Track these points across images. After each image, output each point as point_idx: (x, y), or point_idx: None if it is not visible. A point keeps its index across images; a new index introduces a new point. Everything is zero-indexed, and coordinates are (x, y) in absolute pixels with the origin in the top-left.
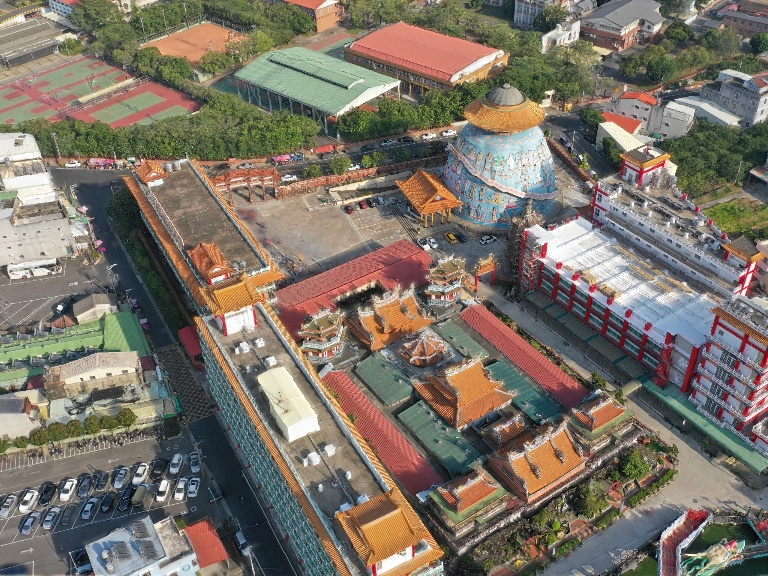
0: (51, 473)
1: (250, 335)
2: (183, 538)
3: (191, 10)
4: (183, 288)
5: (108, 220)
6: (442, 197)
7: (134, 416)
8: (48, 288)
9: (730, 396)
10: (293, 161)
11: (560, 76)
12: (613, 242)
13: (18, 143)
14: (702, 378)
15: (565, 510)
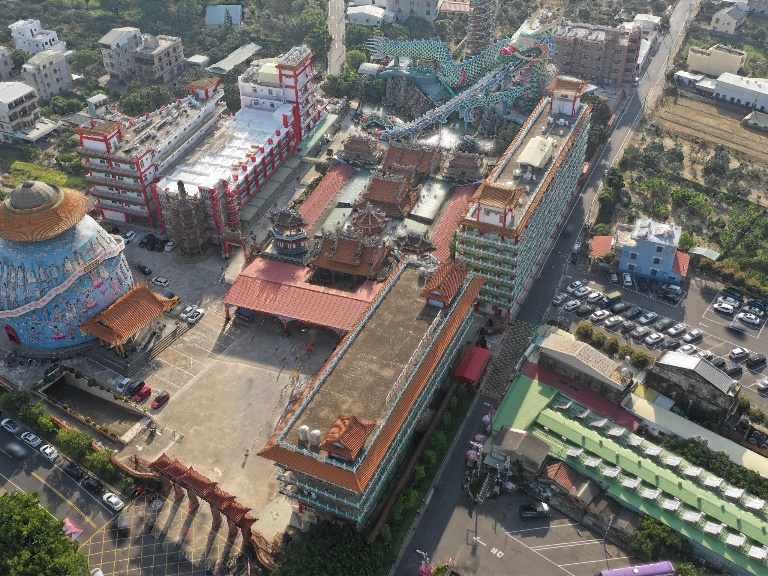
0: None
1: None
2: None
3: None
4: None
5: None
6: None
7: None
8: (529, 572)
9: None
10: None
11: None
12: (183, 166)
13: None
14: None
15: None
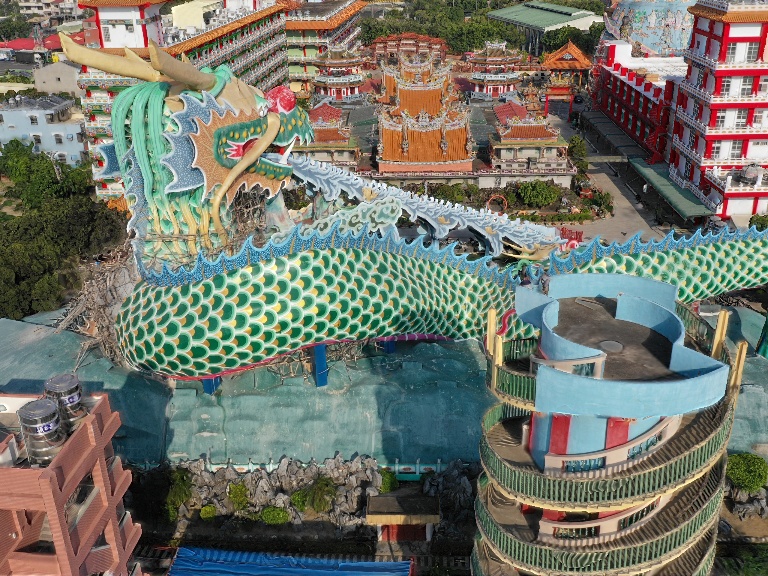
0: None
1: None
2: None
3: (506, 0)
4: None
5: None
6: (573, 57)
7: None
8: None
9: (699, 140)
10: None
11: None
12: None
13: None
14: (684, 133)
15: None
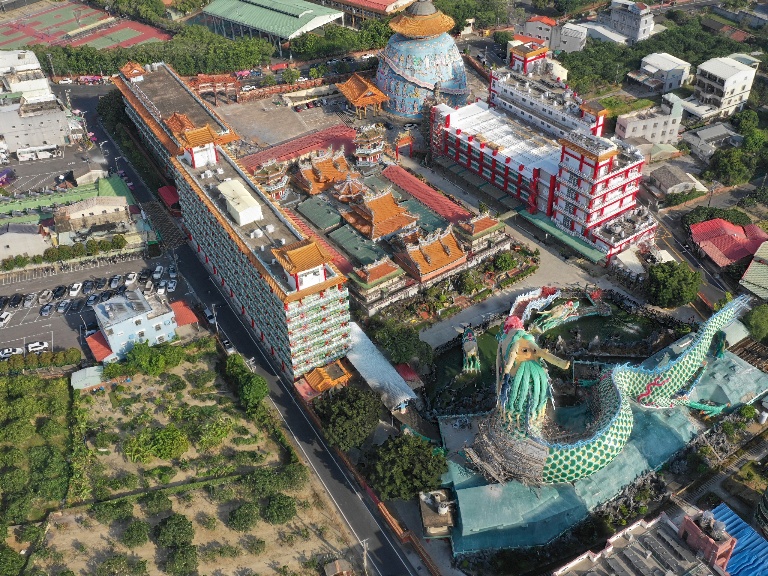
0: (62, 281)
1: (213, 167)
2: (164, 305)
3: None
4: (161, 157)
5: (98, 120)
6: (372, 93)
7: (125, 240)
8: (51, 166)
9: (577, 210)
10: (252, 76)
11: (479, 7)
12: (503, 116)
13: (21, 57)
14: (559, 201)
15: (451, 290)
